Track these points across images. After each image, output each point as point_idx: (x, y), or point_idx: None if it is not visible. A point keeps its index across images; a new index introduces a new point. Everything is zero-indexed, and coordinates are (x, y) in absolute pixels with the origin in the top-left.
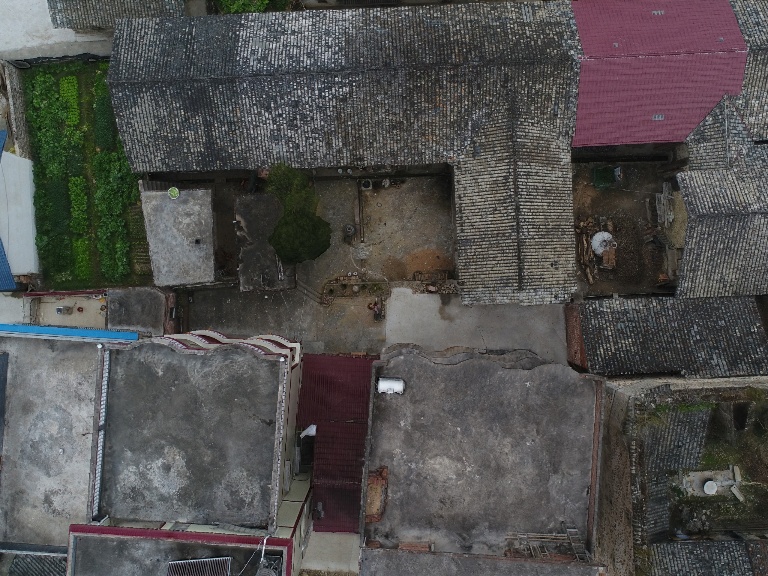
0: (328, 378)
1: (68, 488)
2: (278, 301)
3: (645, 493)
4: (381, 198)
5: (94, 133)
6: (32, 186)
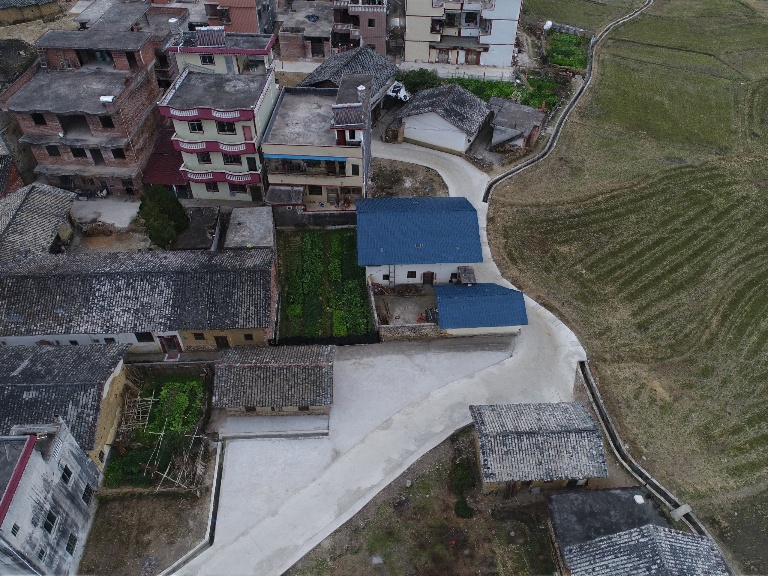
0: (175, 173)
1: None
2: None
3: (4, 84)
4: None
5: None
6: None
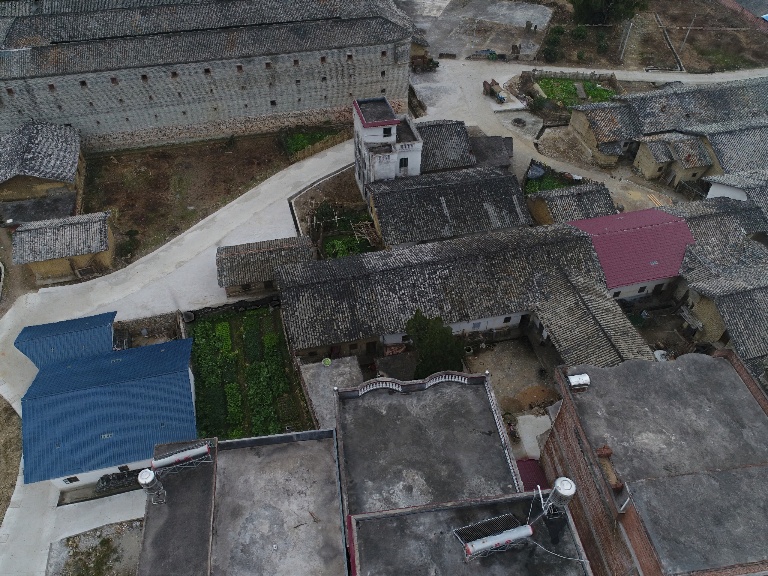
0: None
1: None
2: None
3: None
4: (481, 359)
5: (244, 354)
6: (194, 394)
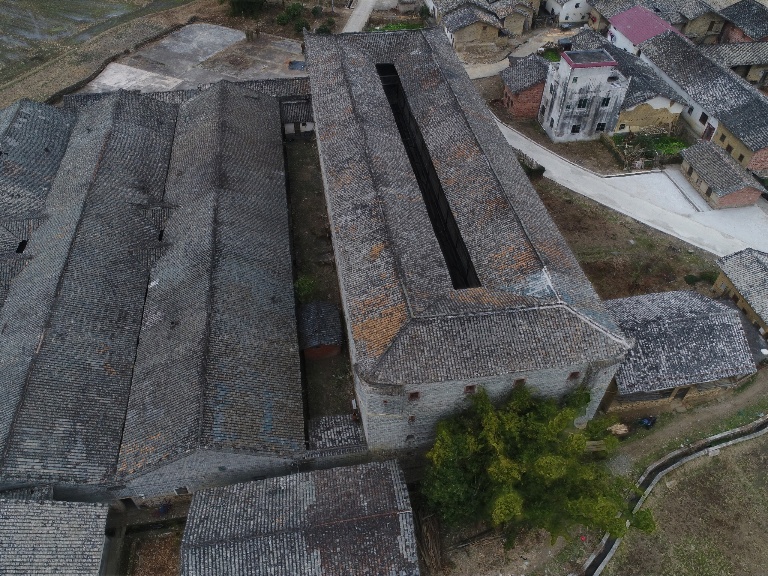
0: None
1: None
2: None
3: None
4: None
5: None
6: None
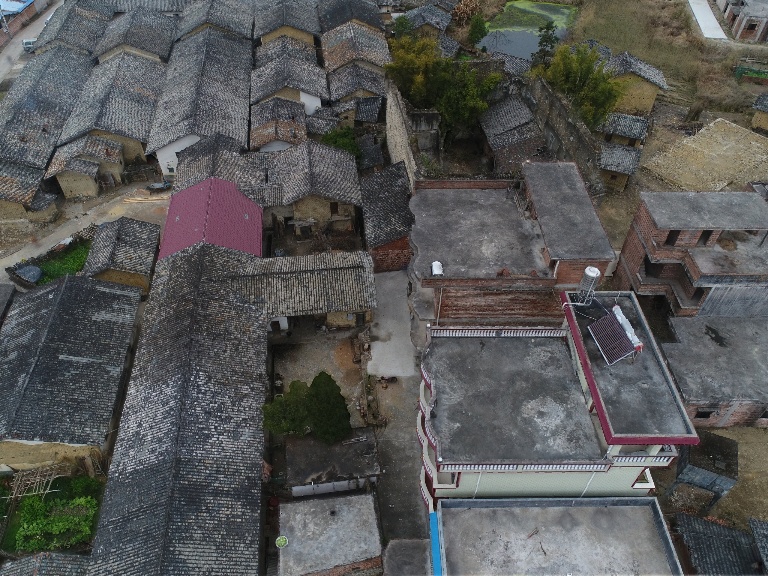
0: None
1: (607, 567)
2: (387, 461)
3: None
4: None
5: None
6: None
